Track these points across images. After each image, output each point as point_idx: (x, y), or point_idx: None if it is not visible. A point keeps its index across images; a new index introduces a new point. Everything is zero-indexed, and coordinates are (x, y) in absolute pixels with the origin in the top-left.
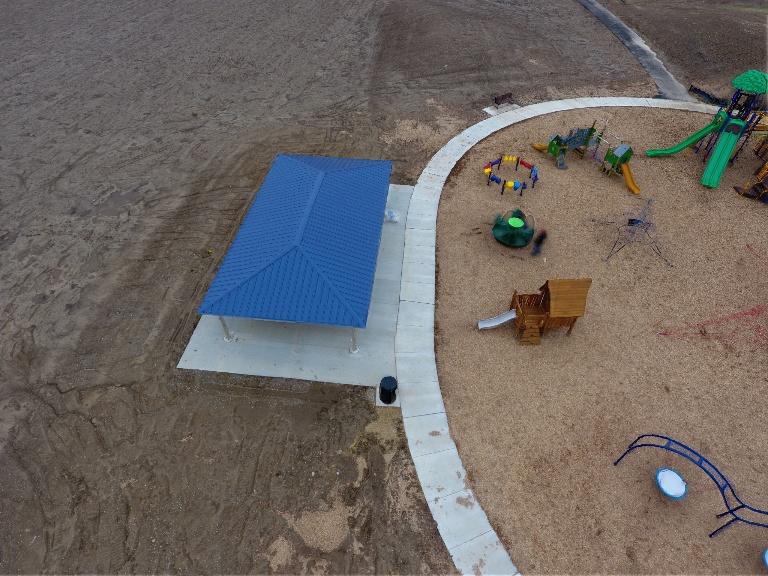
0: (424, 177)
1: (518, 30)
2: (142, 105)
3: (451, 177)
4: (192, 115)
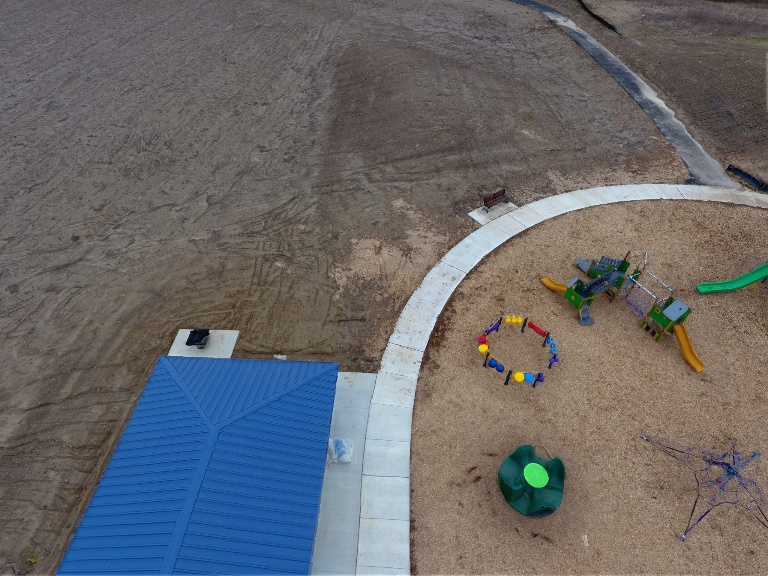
0: (391, 354)
1: (504, 83)
2: (5, 223)
3: (430, 351)
4: (71, 239)
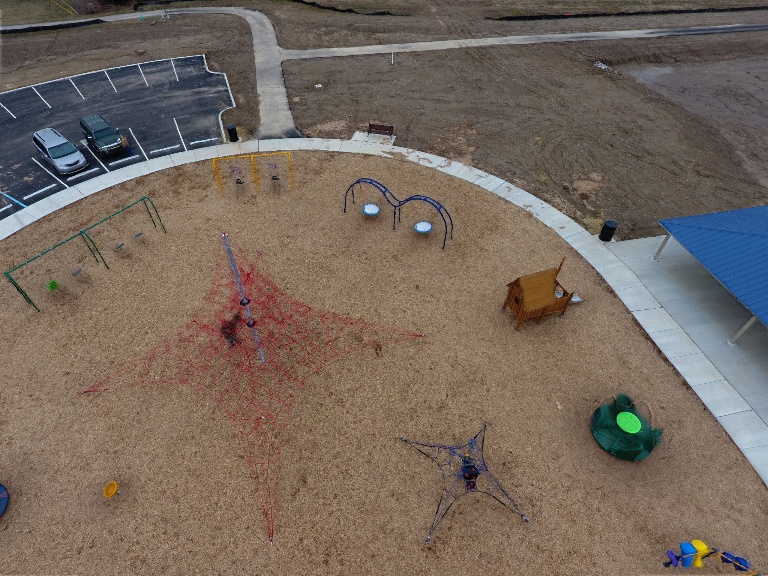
0: None
1: None
2: None
3: None
4: None
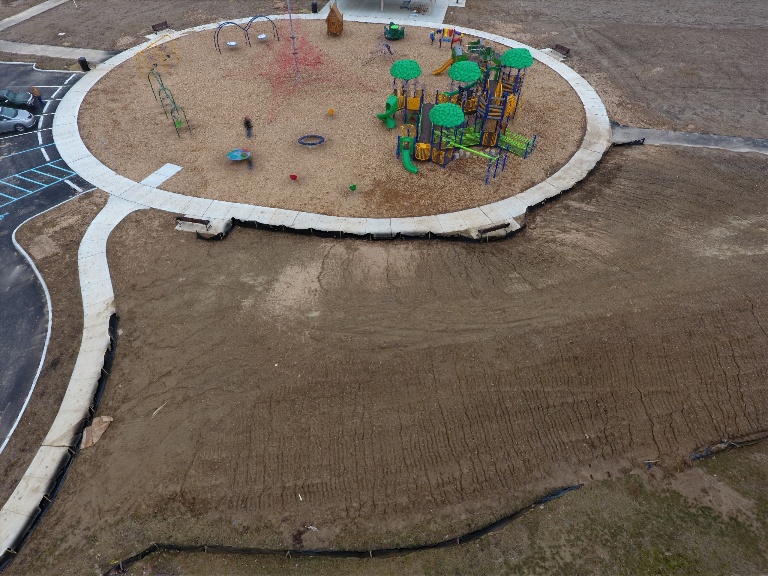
0: None
1: (765, 76)
2: None
3: None
4: None
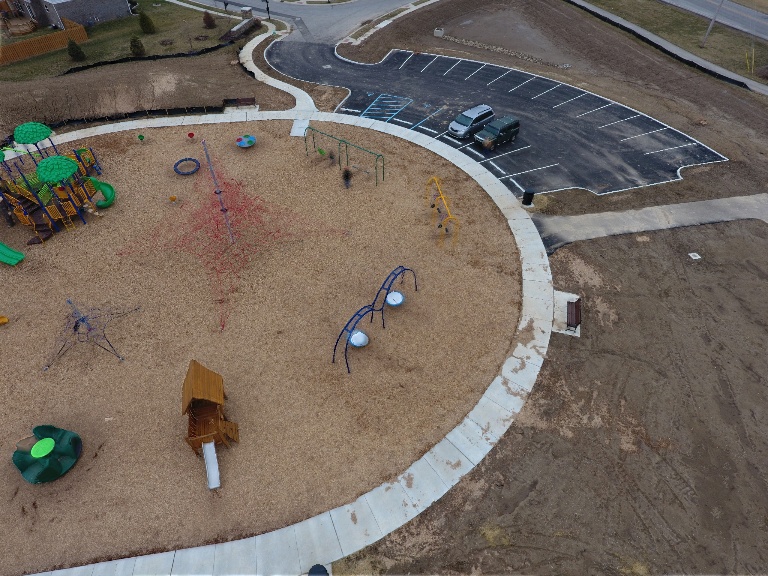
0: None
1: None
2: None
3: None
4: None
